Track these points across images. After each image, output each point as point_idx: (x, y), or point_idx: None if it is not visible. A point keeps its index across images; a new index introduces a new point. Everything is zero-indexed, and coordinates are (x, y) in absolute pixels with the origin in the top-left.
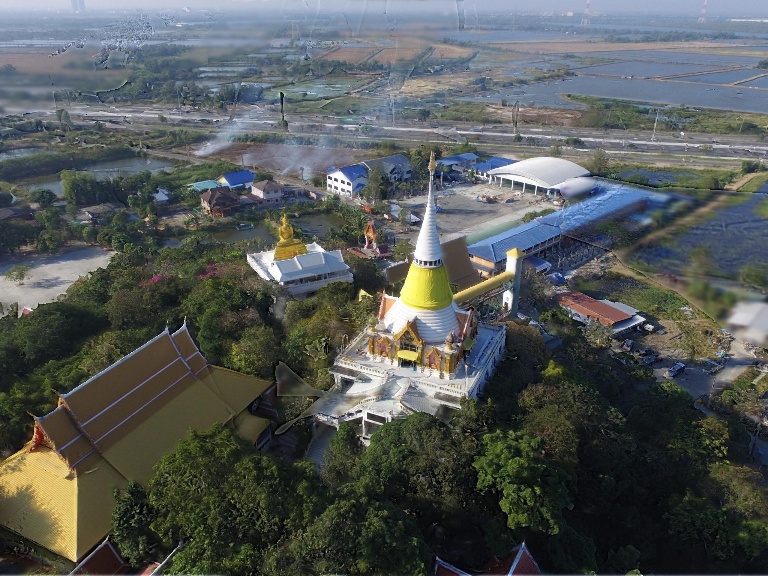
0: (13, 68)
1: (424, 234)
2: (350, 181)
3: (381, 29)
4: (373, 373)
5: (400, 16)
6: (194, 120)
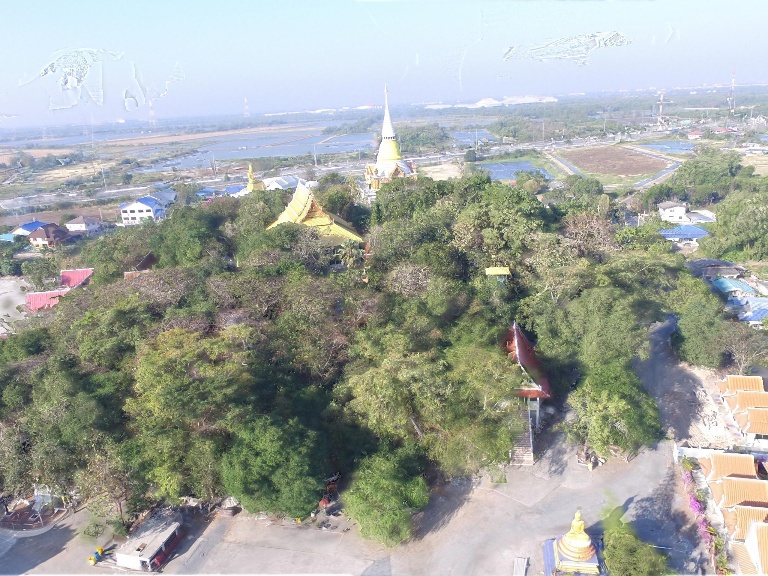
0: (30, 82)
1: (388, 124)
2: (150, 208)
3: (73, 106)
4: None
5: (88, 94)
6: None
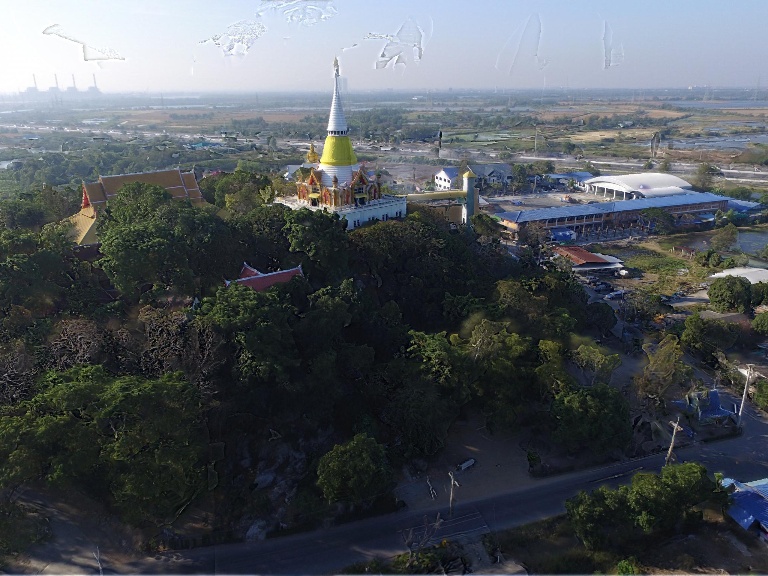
0: None
1: None
2: (449, 178)
3: (531, 69)
4: (291, 205)
5: (550, 57)
6: (367, 147)
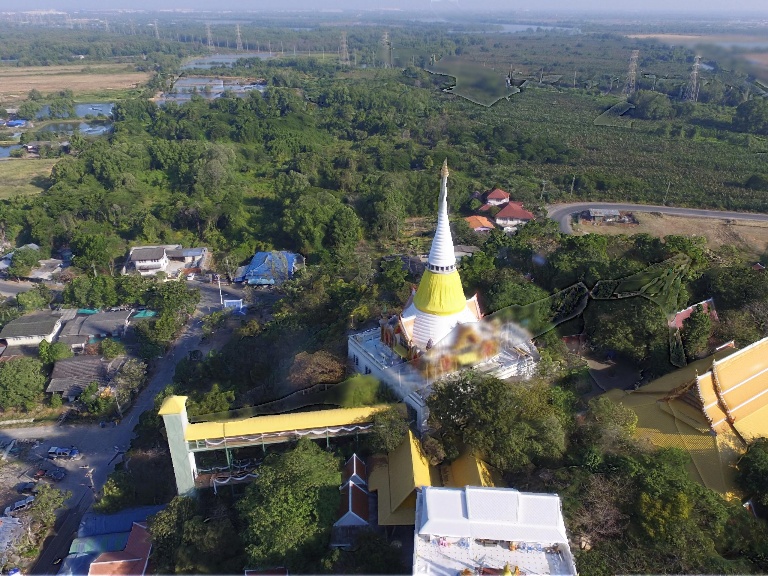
0: None
1: None
2: None
3: None
4: None
5: None
6: None
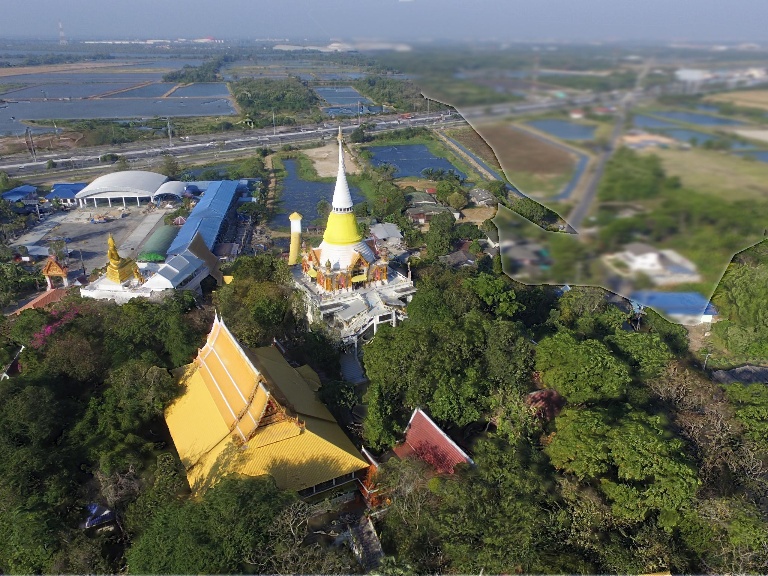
0: None
1: (344, 188)
2: None
3: None
4: (349, 299)
5: None
6: None
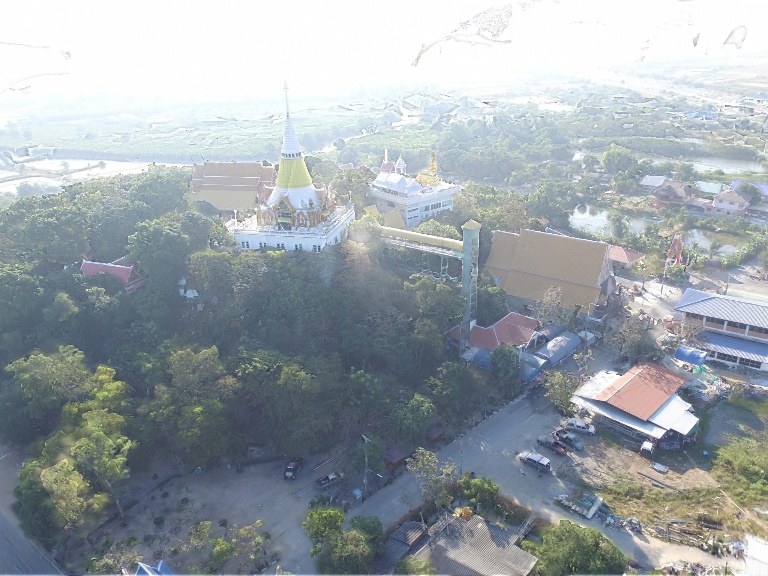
0: None
1: None
2: None
3: None
4: None
5: None
6: None
